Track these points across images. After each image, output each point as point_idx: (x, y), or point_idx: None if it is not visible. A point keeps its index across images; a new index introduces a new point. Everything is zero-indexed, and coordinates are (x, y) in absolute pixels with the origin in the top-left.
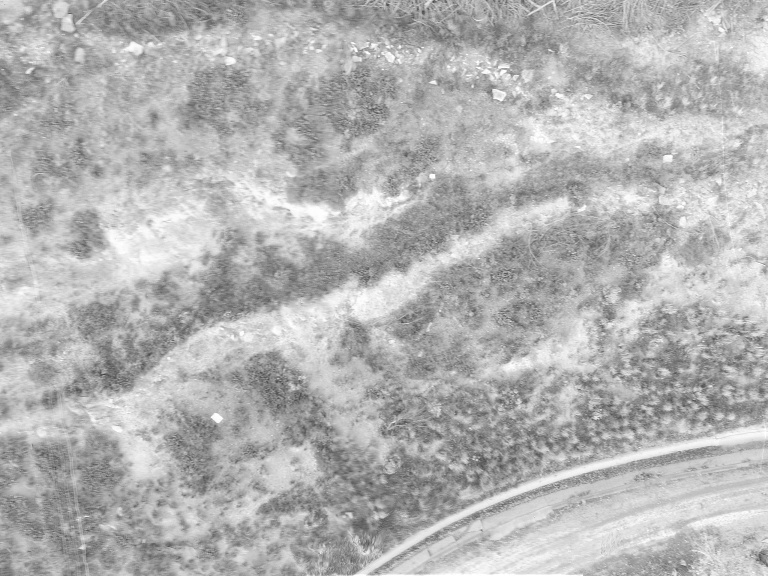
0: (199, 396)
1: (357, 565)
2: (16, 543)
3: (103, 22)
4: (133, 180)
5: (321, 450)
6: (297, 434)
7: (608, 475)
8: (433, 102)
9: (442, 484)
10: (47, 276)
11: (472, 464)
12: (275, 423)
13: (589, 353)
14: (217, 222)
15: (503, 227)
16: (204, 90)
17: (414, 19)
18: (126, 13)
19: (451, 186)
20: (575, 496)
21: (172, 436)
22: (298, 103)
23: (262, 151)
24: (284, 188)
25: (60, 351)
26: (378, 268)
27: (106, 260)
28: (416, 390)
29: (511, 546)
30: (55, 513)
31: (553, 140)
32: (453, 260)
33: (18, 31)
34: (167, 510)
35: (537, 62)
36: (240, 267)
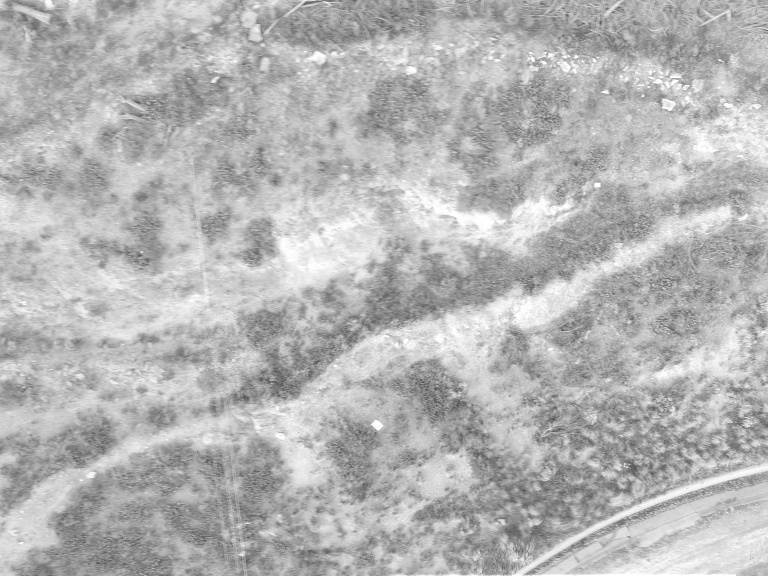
0: (361, 403)
1: (507, 572)
2: (178, 550)
3: (289, 32)
4: (309, 189)
5: (477, 457)
6: (454, 441)
7: (753, 482)
8: (604, 111)
9: (593, 491)
10: (217, 284)
11: (624, 471)
12: (432, 430)
13: (740, 361)
14: (383, 230)
15: (666, 236)
16: (384, 99)
17: (591, 29)
18: (311, 23)
19: (615, 195)
20: (722, 503)
21: (334, 443)
22: (475, 112)
23: (436, 160)
24: (456, 197)
25: (229, 358)
26: (542, 276)
27: (274, 268)
28: (571, 397)
29: (660, 553)
30: (217, 520)
31: (716, 149)
32: (615, 268)
33: (206, 40)
34: (325, 517)
35: (707, 72)
36: (405, 275)
